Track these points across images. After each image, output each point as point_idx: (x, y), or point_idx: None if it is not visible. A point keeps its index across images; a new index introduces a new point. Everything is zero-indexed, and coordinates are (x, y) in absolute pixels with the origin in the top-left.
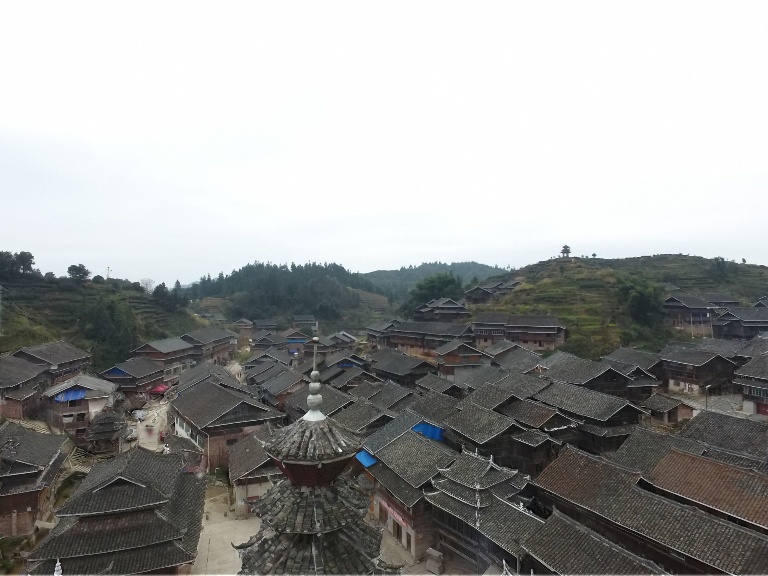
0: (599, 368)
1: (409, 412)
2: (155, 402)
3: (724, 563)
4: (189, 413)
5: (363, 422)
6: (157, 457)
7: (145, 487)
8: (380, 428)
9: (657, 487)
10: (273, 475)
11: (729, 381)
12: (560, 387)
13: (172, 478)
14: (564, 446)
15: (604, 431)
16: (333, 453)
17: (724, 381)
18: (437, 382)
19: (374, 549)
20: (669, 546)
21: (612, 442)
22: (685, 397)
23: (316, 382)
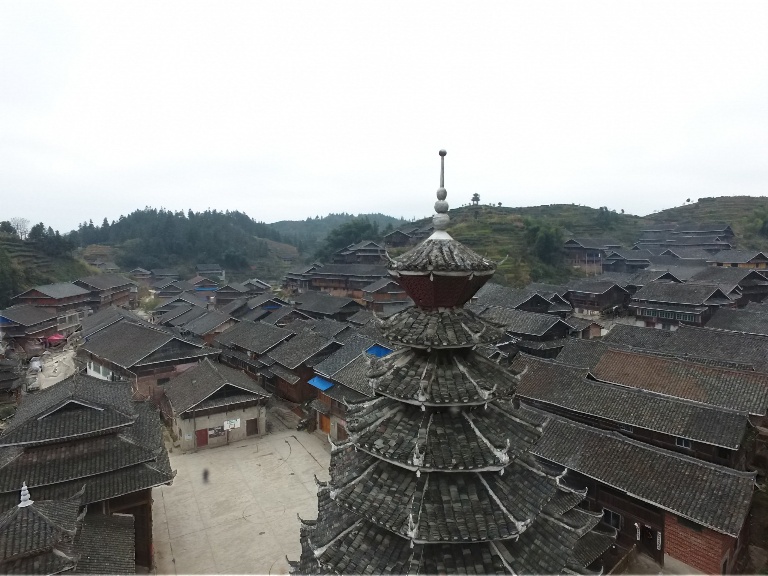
0: (526, 294)
1: (360, 337)
2: (56, 349)
3: (669, 428)
4: (108, 354)
5: (312, 350)
6: (104, 384)
7: (103, 410)
8: (332, 354)
9: (600, 380)
10: (223, 406)
11: (623, 306)
12: (496, 311)
13: (129, 403)
14: (517, 354)
15: (540, 345)
16: (482, 265)
17: (620, 306)
18: (370, 317)
19: None
20: (622, 422)
21: (545, 355)
22: (596, 317)
23: None
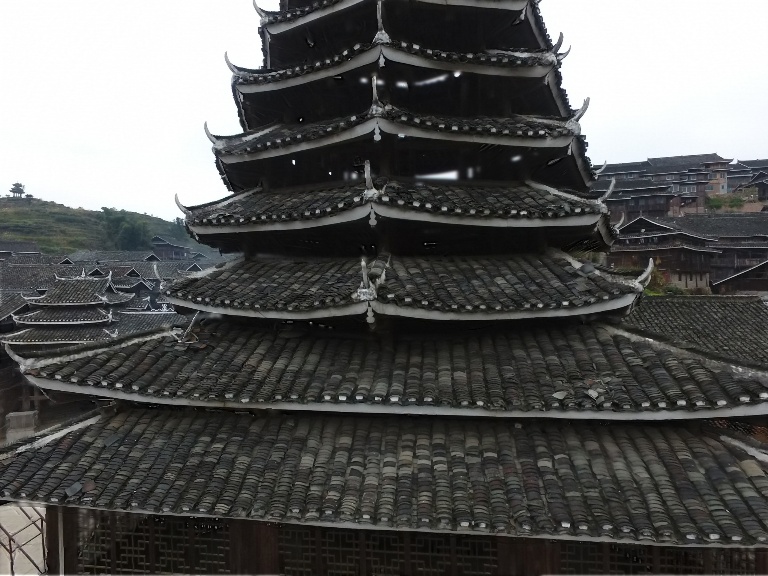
0: (141, 255)
1: None
2: None
3: None
4: None
5: None
6: None
7: None
8: None
9: None
10: None
11: None
12: None
13: None
14: (175, 272)
15: None
16: None
17: None
18: None
19: None
20: None
21: None
22: None
23: None
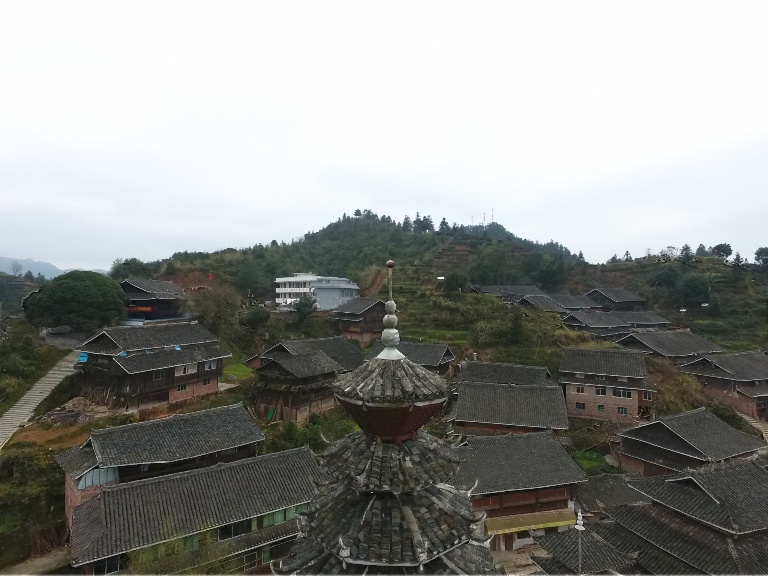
0: None
1: None
2: None
3: None
4: None
5: None
6: None
7: (719, 503)
8: None
9: None
10: None
11: None
12: None
13: None
14: None
15: None
16: (342, 389)
17: None
18: None
19: (376, 550)
20: None
21: None
22: None
23: (388, 313)
